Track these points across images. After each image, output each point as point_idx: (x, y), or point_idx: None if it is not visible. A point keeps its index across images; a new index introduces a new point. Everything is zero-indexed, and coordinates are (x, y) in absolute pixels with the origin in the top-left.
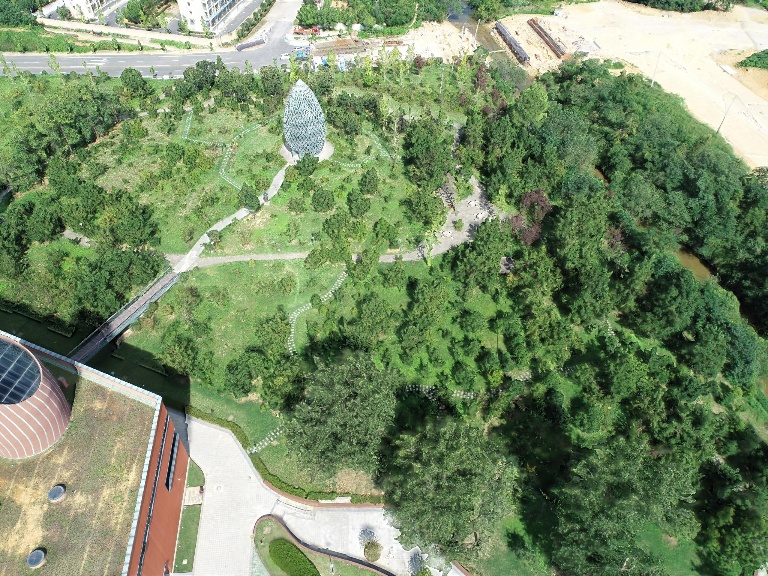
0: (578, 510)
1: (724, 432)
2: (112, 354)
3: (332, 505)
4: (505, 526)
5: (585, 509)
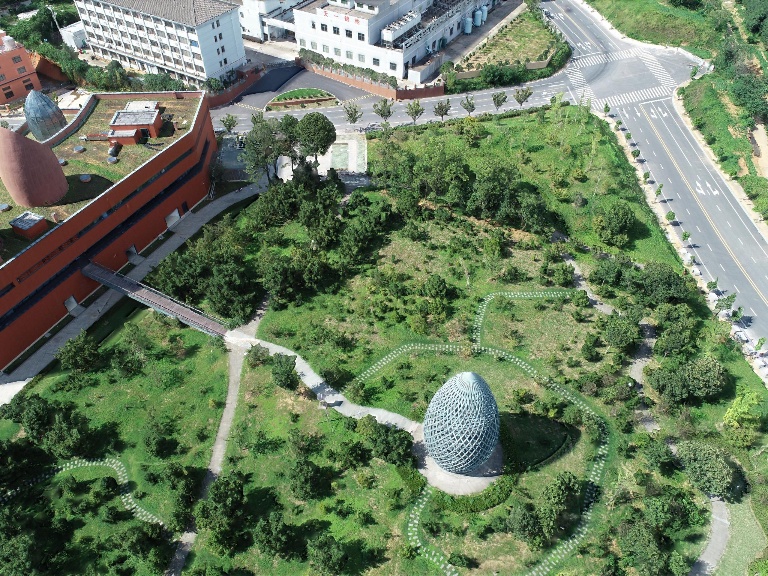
0: None
1: None
2: (138, 308)
3: None
4: None
5: None
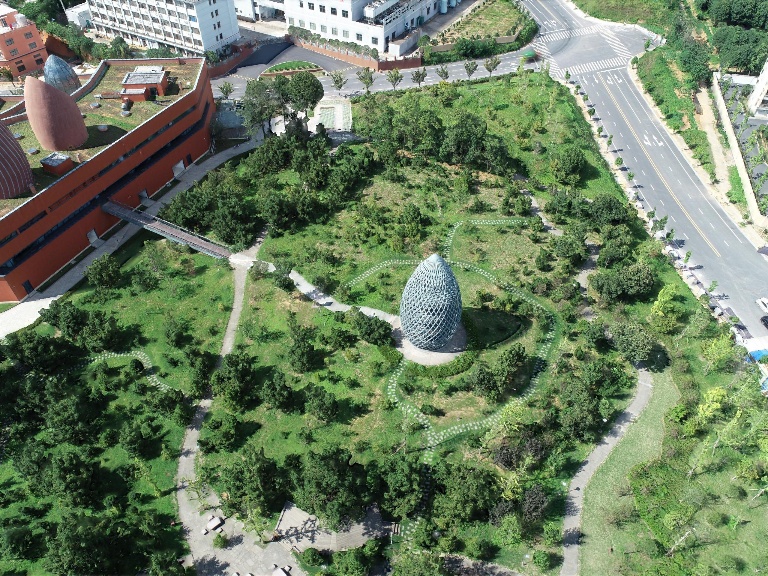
0: None
1: None
2: (152, 239)
3: None
4: None
5: None
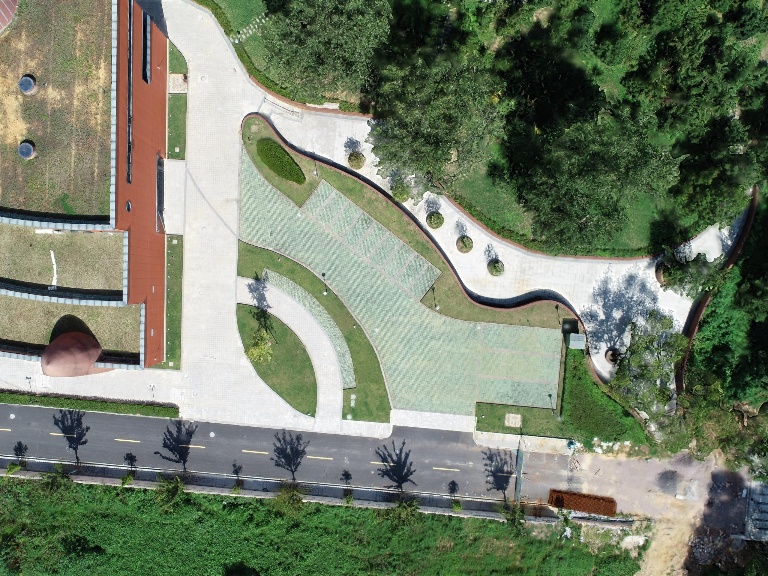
0: (557, 166)
1: (758, 82)
2: None
3: (320, 110)
4: (490, 152)
5: (563, 171)
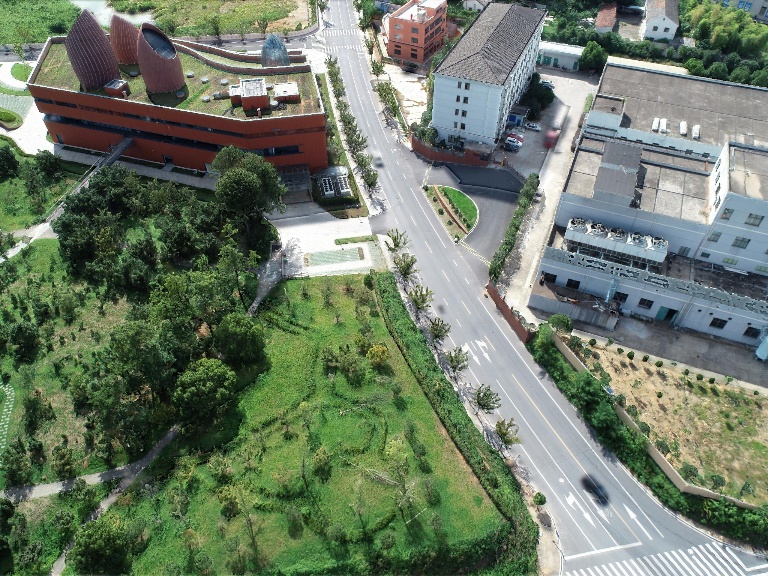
0: None
1: None
2: None
3: None
4: None
5: None
